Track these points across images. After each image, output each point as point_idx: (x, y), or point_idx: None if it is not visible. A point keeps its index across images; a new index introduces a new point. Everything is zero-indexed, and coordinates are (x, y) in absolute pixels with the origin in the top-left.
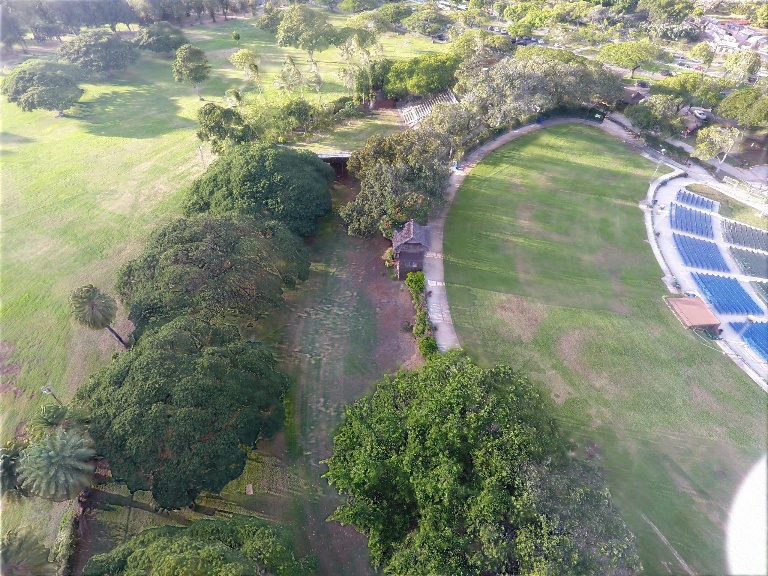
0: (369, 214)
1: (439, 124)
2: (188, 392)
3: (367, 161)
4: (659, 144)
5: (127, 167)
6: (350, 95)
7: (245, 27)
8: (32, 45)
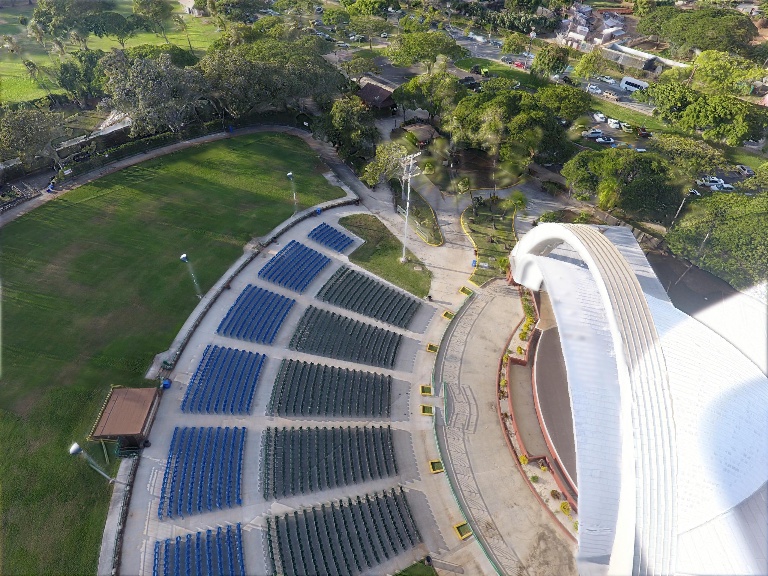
0: None
1: (4, 136)
2: None
3: None
4: (350, 161)
5: None
6: None
7: None
8: None
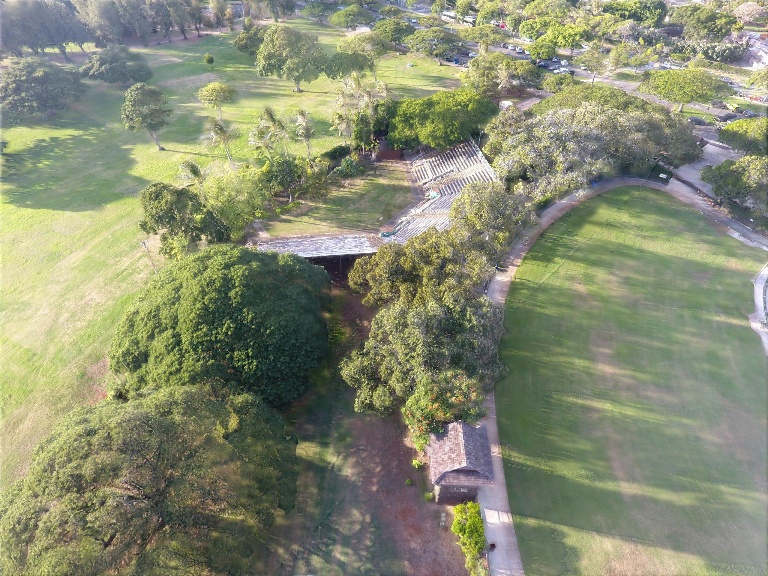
0: (386, 381)
1: (475, 214)
2: None
3: (379, 282)
4: (749, 218)
5: (51, 260)
6: (346, 140)
7: (221, 46)
8: None
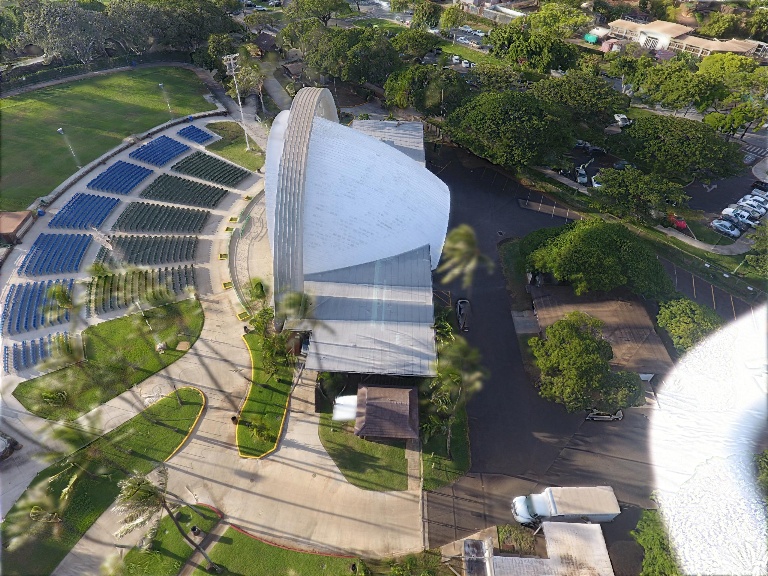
0: None
1: None
2: None
3: None
4: (226, 85)
5: None
6: None
7: None
8: None
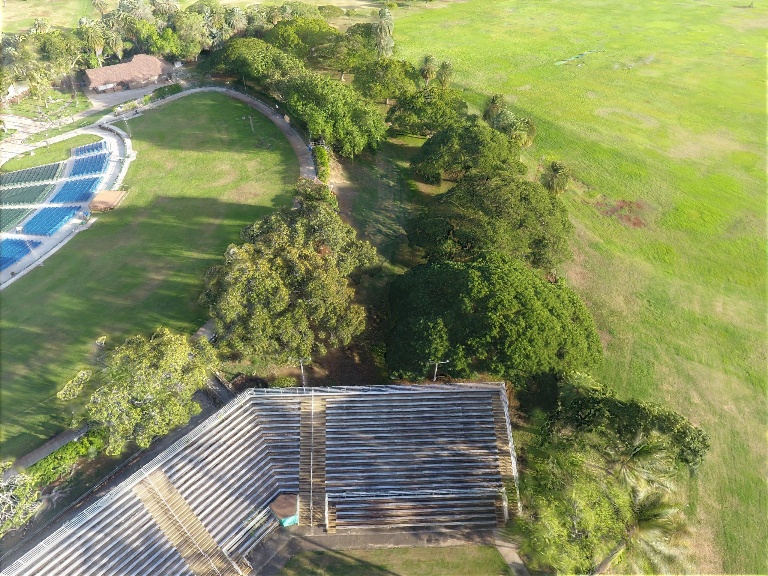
0: None
1: None
2: None
3: None
4: None
5: None
6: None
7: None
8: None
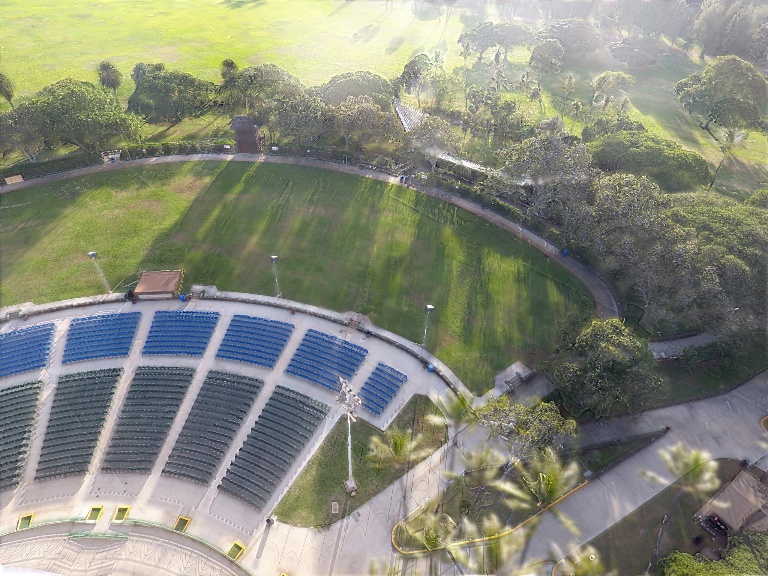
0: None
1: None
2: (155, 82)
3: None
4: None
5: None
6: None
7: None
8: (598, 30)
